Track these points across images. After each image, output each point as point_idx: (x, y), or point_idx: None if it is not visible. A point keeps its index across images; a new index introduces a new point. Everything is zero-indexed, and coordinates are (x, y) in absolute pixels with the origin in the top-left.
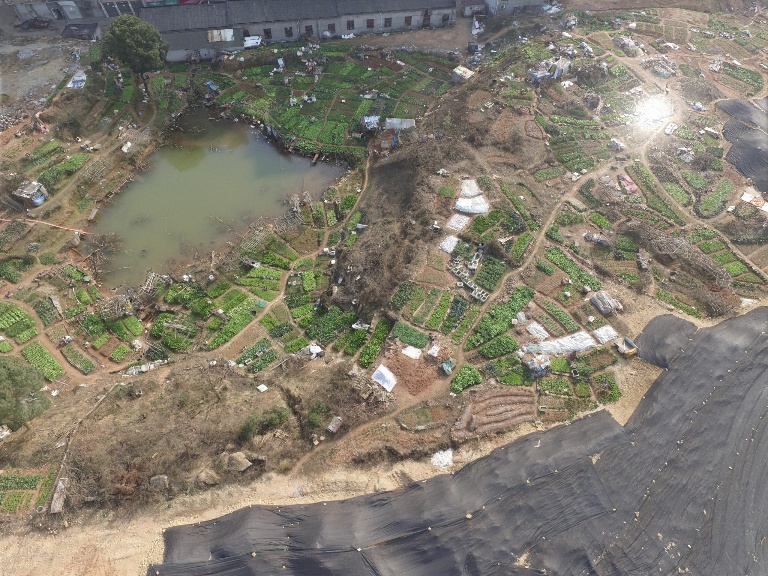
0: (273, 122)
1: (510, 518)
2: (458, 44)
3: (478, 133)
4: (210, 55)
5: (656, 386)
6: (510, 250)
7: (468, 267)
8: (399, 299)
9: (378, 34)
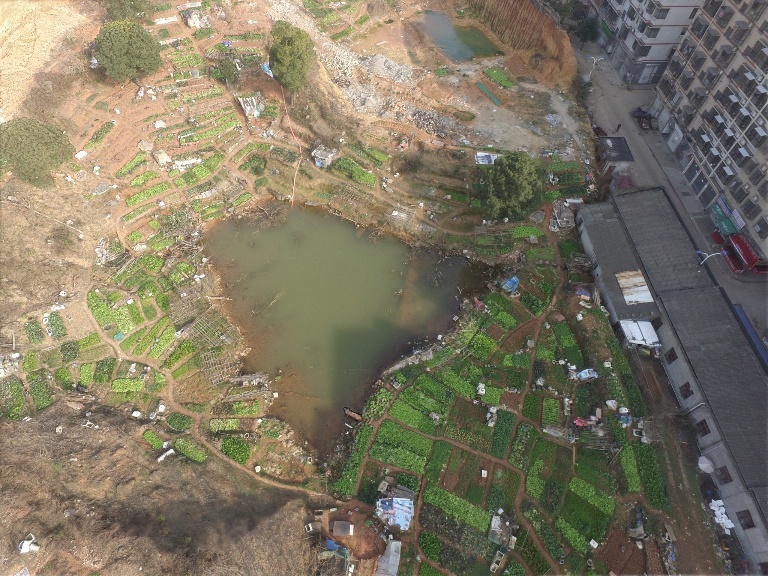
0: (437, 360)
1: None
2: None
3: None
4: None
5: None
6: None
7: None
8: None
9: None
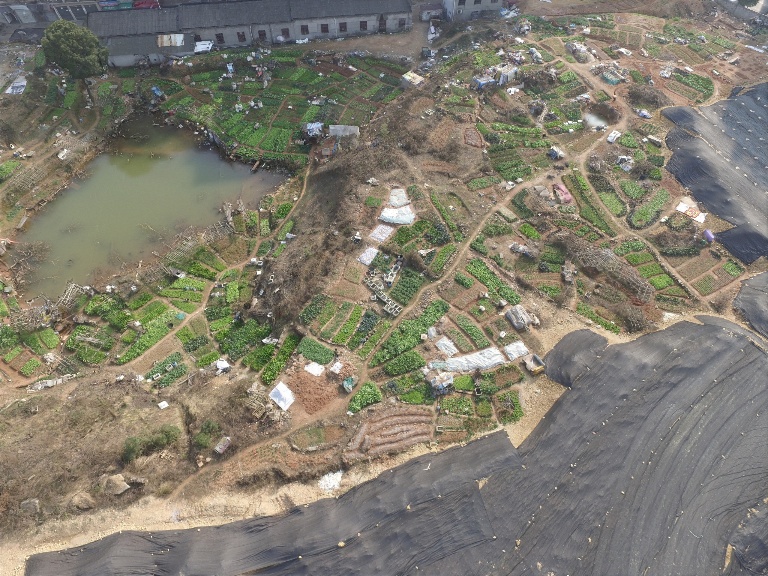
0: (216, 128)
1: (385, 546)
2: (412, 49)
3: (414, 141)
4: (160, 60)
5: (557, 406)
6: (431, 262)
7: (384, 280)
8: (309, 313)
9: (333, 39)
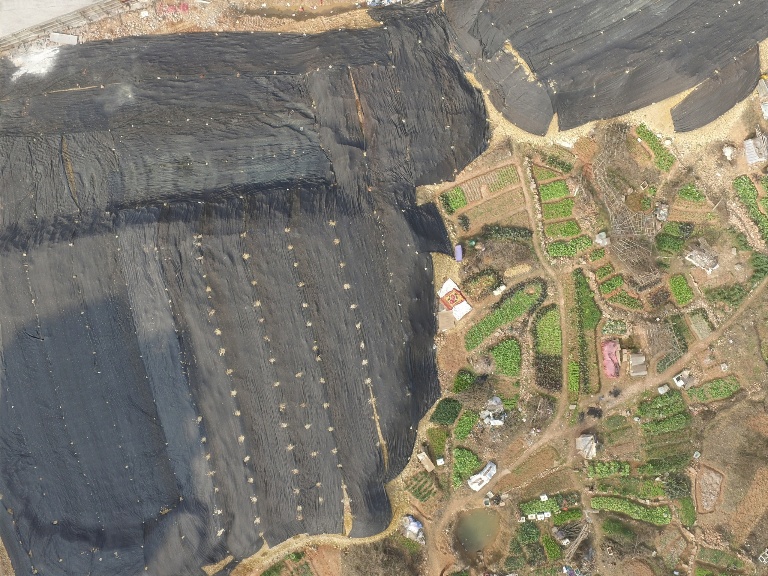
0: None
1: None
2: None
3: None
4: None
5: None
6: None
7: None
8: None
9: None
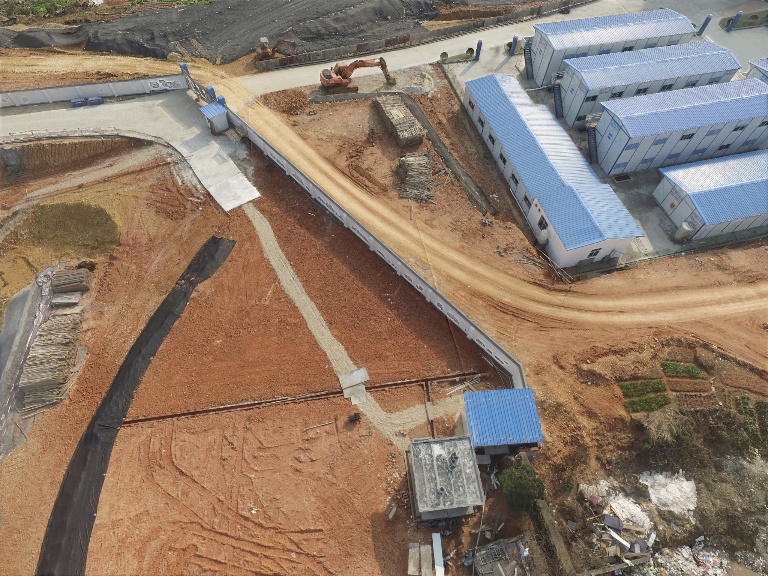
0: None
1: None
2: None
3: None
4: None
5: None
6: None
7: None
8: None
9: None
